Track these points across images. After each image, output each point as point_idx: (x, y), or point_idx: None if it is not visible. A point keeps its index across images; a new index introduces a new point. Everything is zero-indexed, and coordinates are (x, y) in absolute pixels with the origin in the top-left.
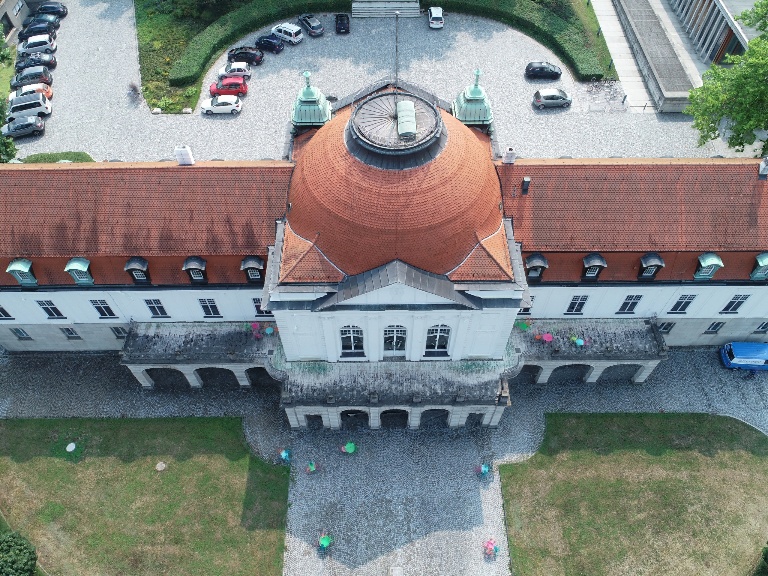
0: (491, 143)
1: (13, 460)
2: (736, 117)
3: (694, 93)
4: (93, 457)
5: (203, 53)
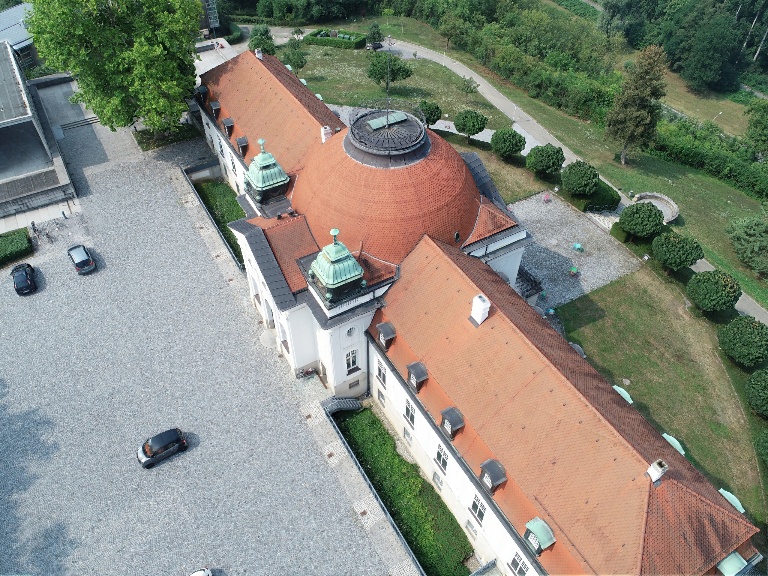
0: None
1: (732, 491)
2: (185, 84)
3: None
4: (668, 432)
5: None
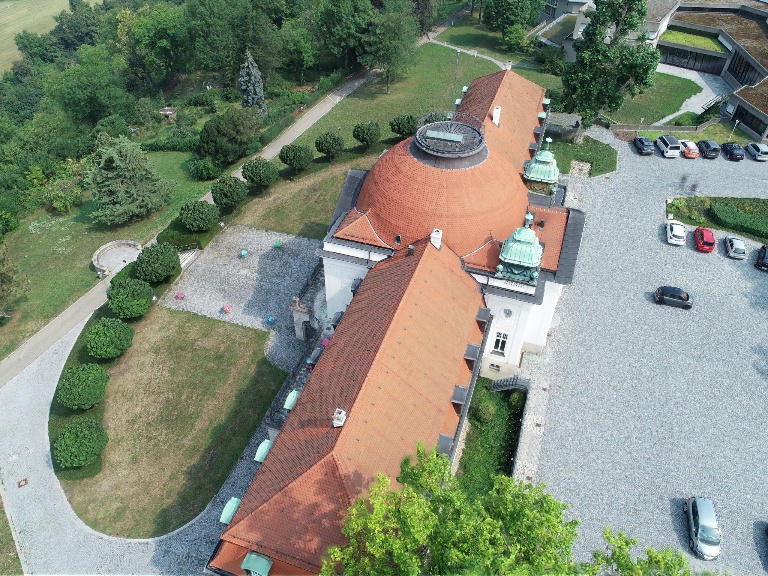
0: (490, 273)
1: None
2: None
3: None
4: None
5: (760, 227)
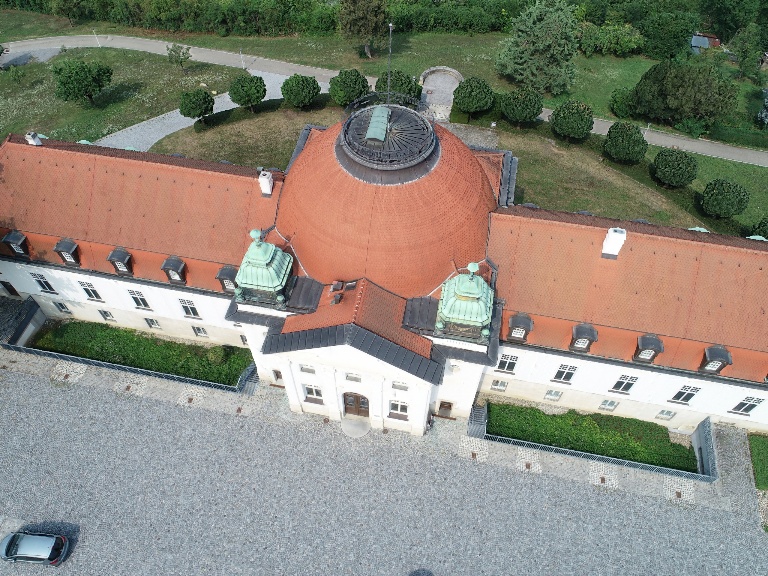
0: None
1: None
2: None
3: None
4: None
5: None
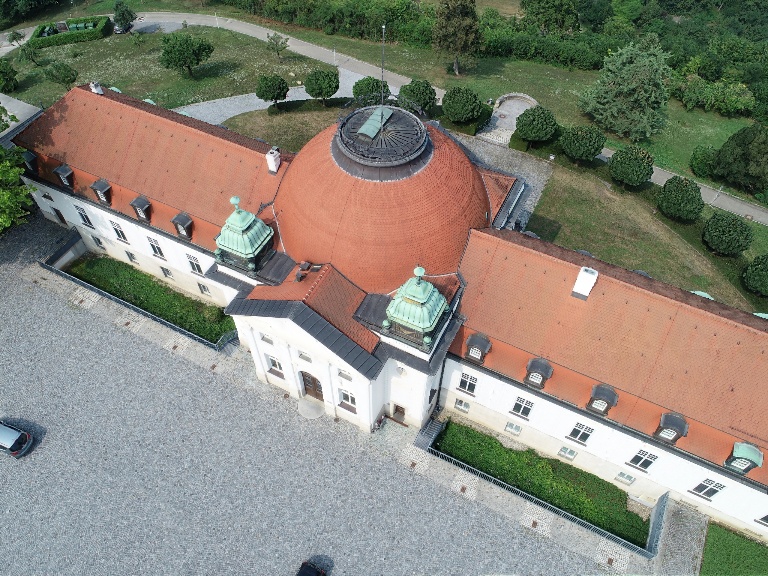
0: None
1: None
2: None
3: None
4: None
5: None
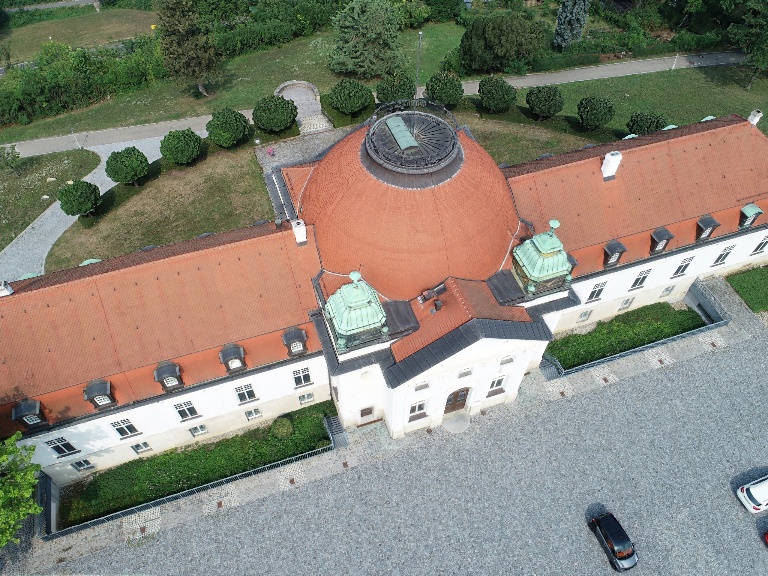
0: None
1: None
2: None
3: (26, 481)
4: None
5: None
